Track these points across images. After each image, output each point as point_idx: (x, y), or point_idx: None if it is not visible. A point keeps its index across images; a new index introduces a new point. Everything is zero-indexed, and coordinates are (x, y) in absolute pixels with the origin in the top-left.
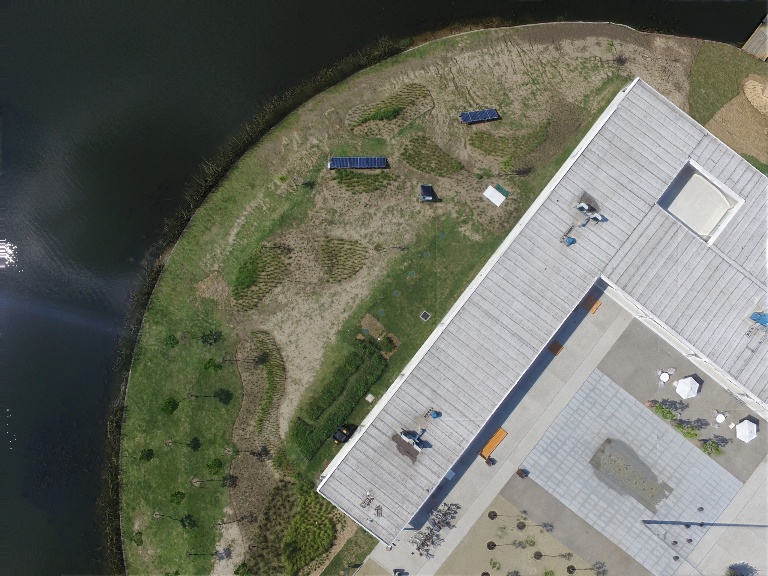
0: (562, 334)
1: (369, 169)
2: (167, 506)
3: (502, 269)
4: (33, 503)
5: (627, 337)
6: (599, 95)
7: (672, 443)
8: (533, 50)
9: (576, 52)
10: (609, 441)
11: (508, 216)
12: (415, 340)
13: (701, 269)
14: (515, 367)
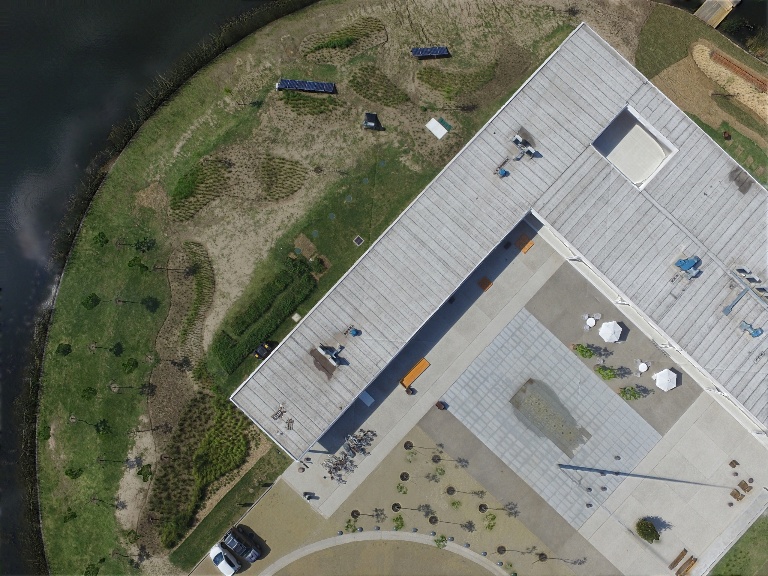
0: (493, 271)
1: (317, 93)
2: (84, 410)
3: (434, 195)
4: None
5: (557, 279)
6: (548, 42)
7: (594, 389)
8: None
9: (530, 1)
10: (531, 381)
11: (448, 150)
12: (346, 264)
13: (630, 213)
14: (439, 292)
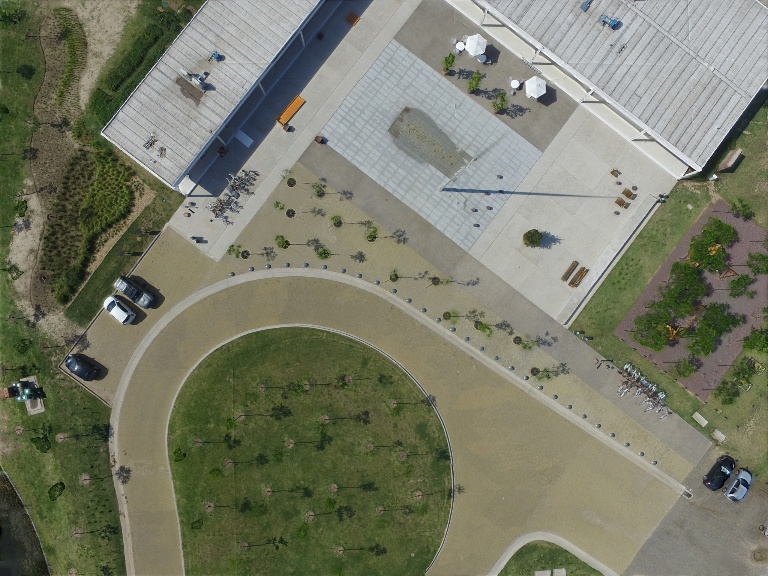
0: (359, 6)
1: None
2: None
3: None
4: None
5: (423, 9)
6: None
7: (470, 112)
8: None
9: None
10: (407, 110)
11: None
12: None
13: None
14: (298, 12)
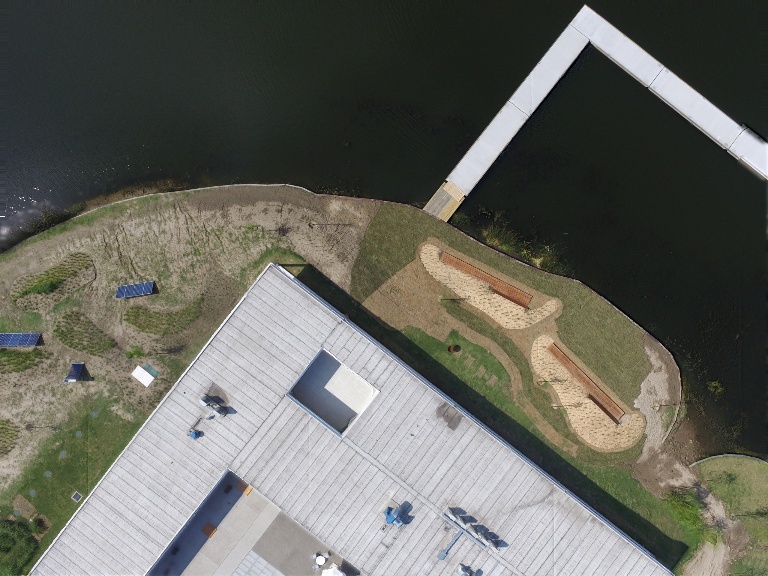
0: (216, 516)
1: None
2: None
3: (127, 463)
4: None
5: (283, 518)
6: (256, 269)
7: None
8: (200, 217)
9: (241, 220)
10: None
11: (158, 396)
12: (66, 521)
13: (333, 462)
14: (140, 563)
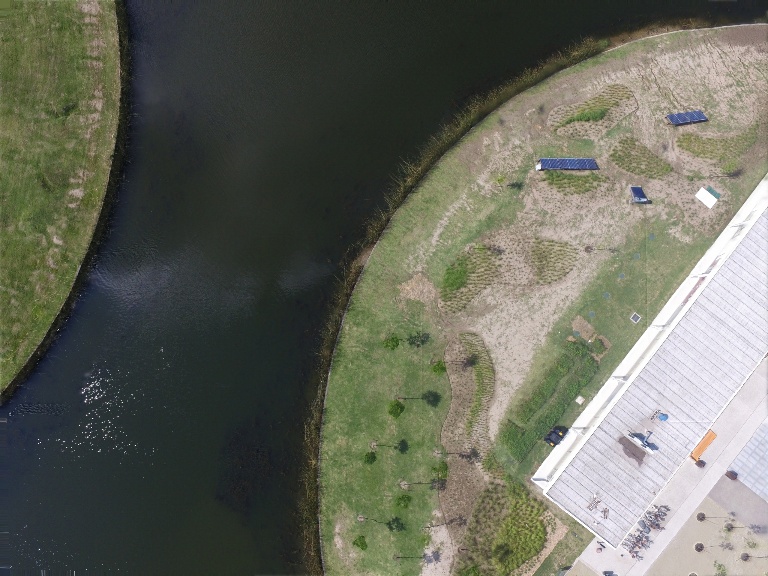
0: None
1: (578, 170)
2: (372, 509)
3: (728, 271)
4: (227, 506)
5: None
6: None
7: None
8: (734, 52)
9: None
10: None
11: (719, 218)
12: (626, 342)
13: None
14: (741, 369)
